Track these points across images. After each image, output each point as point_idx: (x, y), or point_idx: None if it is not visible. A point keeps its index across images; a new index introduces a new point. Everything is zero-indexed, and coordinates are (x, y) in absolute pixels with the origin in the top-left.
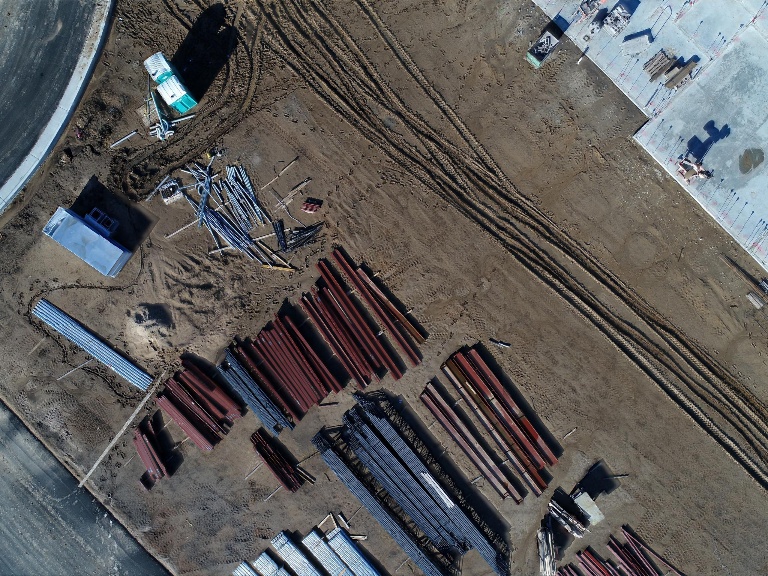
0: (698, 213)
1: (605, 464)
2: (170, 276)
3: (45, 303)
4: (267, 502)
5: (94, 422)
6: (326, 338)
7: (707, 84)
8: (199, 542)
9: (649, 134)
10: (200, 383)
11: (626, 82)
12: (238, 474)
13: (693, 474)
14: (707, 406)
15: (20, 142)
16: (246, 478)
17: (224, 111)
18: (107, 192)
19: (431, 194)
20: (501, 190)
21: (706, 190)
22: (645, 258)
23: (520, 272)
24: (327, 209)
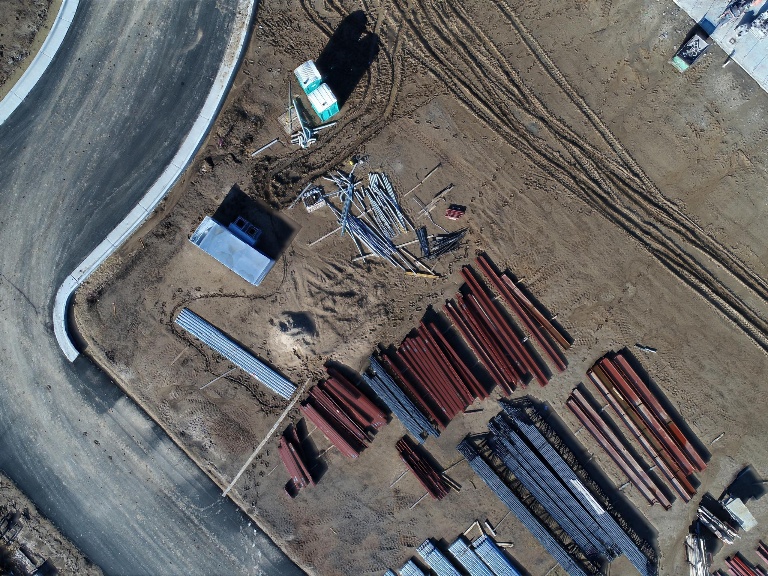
0: None
1: (754, 469)
2: (313, 284)
3: (188, 312)
4: (412, 510)
5: (237, 431)
6: (471, 345)
7: None
8: (344, 551)
9: None
10: (345, 391)
11: None
12: (383, 482)
13: None
14: None
15: (161, 151)
16: (391, 486)
17: (366, 118)
18: (249, 200)
19: (575, 199)
20: (646, 194)
21: None
22: None
23: (666, 277)
24: (470, 215)
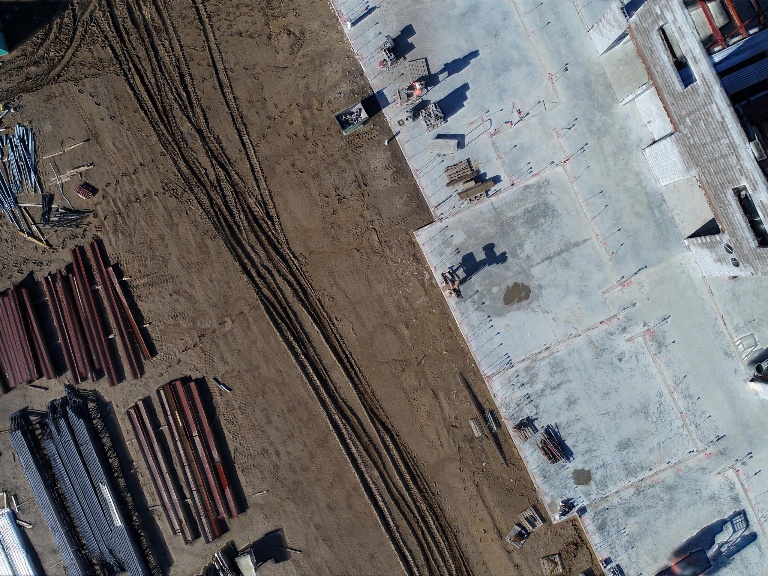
0: (451, 327)
1: (283, 534)
2: None
3: None
4: None
5: None
6: (56, 323)
7: (501, 207)
8: None
9: (429, 235)
10: None
11: (424, 178)
12: None
13: (362, 571)
14: (397, 512)
15: None
16: None
17: (32, 70)
18: None
19: (205, 220)
20: (273, 239)
21: (464, 307)
22: (387, 352)
23: (265, 324)
24: (100, 200)
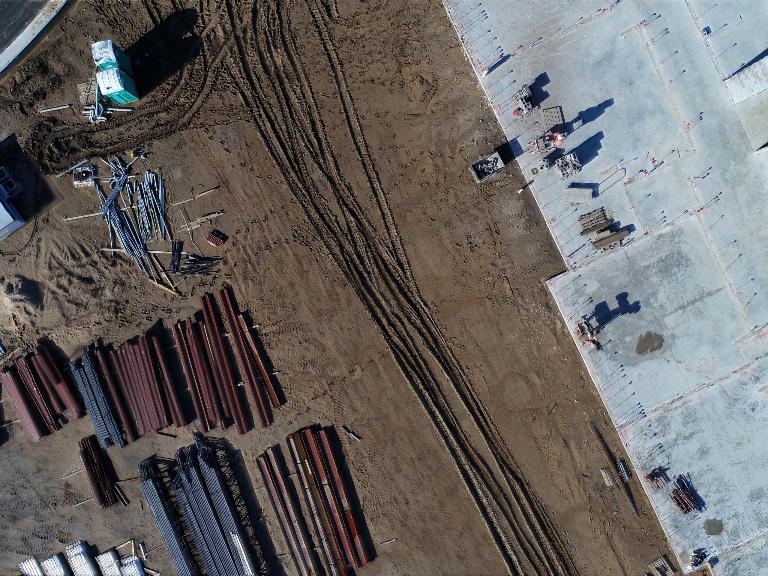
0: (583, 375)
1: None
2: (55, 258)
3: None
4: (75, 508)
5: None
6: (185, 371)
7: (634, 256)
8: None
9: (562, 284)
10: (49, 372)
11: (558, 227)
12: (56, 472)
13: None
14: (527, 561)
15: None
16: (63, 478)
17: (163, 116)
18: (21, 155)
19: (335, 267)
20: (404, 287)
21: (597, 357)
22: (518, 400)
23: (394, 372)
24: (230, 247)
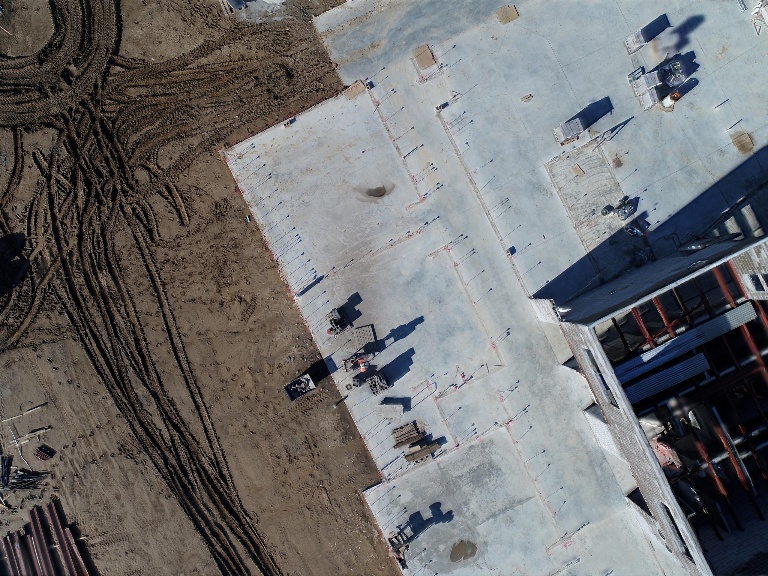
0: None
1: None
2: None
3: None
4: None
5: None
6: None
7: (446, 467)
8: None
9: (377, 496)
10: None
11: (372, 440)
12: None
13: None
14: None
15: None
16: None
17: None
18: None
19: (160, 479)
20: (226, 498)
21: (412, 565)
22: None
23: None
24: (58, 461)
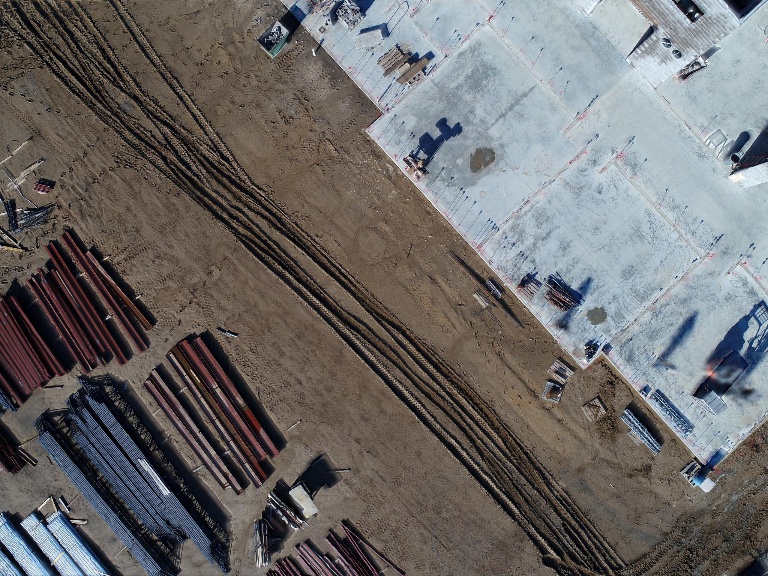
0: (428, 210)
1: (328, 458)
2: None
3: None
4: None
5: None
6: (52, 320)
7: (441, 81)
8: None
9: (381, 129)
10: None
11: (360, 76)
12: None
13: (415, 471)
14: (431, 403)
15: None
16: None
17: None
18: None
19: (165, 180)
20: (235, 179)
21: (436, 187)
22: (375, 253)
23: (250, 262)
24: (59, 190)
